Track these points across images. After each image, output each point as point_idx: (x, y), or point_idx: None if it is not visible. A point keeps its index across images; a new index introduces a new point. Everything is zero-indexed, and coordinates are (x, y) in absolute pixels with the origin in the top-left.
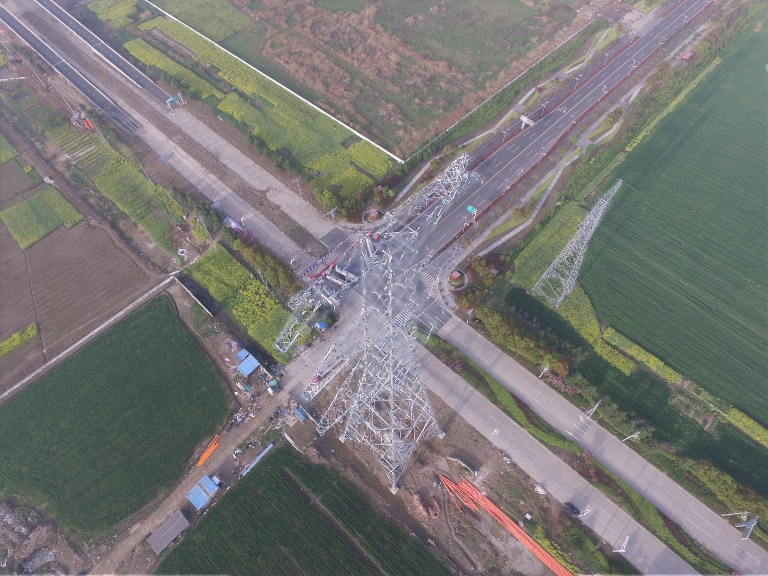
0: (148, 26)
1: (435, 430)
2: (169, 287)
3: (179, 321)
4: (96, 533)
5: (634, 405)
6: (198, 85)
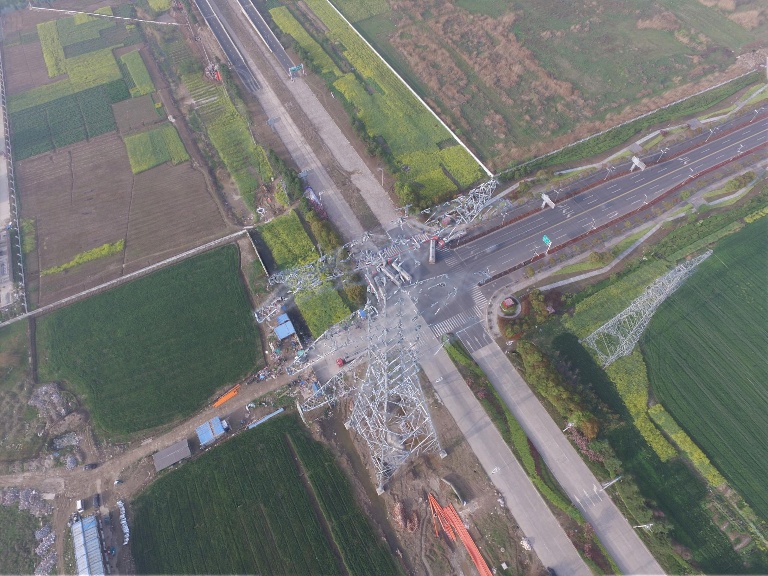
0: None
1: (436, 447)
2: (240, 239)
3: (239, 272)
4: (116, 434)
5: (659, 494)
6: (322, 60)
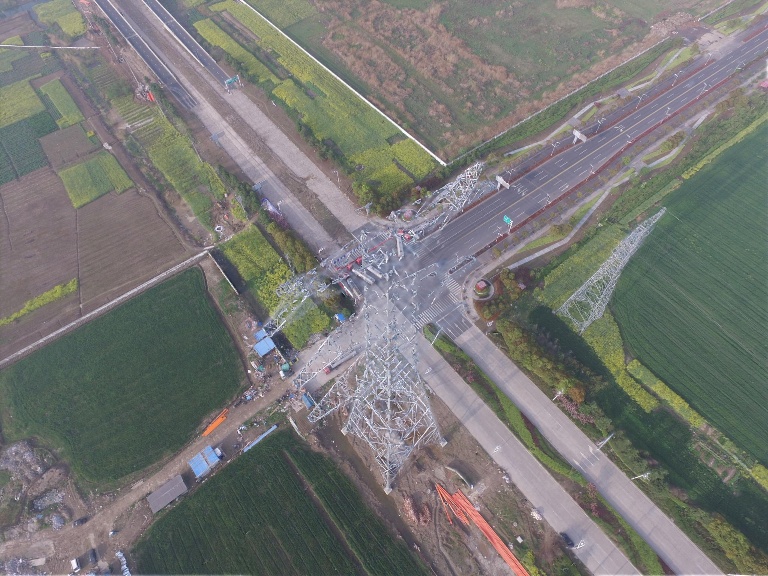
0: (219, 8)
1: (436, 437)
2: (202, 261)
3: (206, 294)
4: (102, 483)
5: (650, 444)
6: (257, 69)
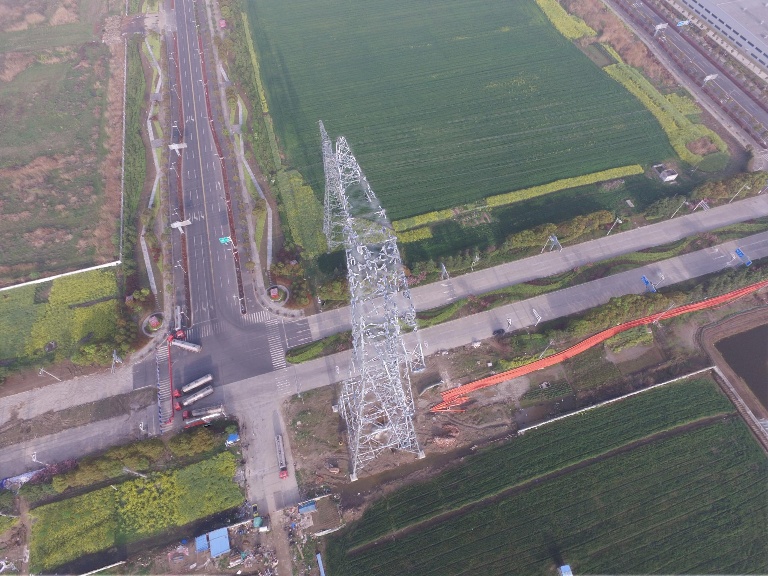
0: None
1: None
2: None
3: None
4: None
5: (453, 248)
6: None
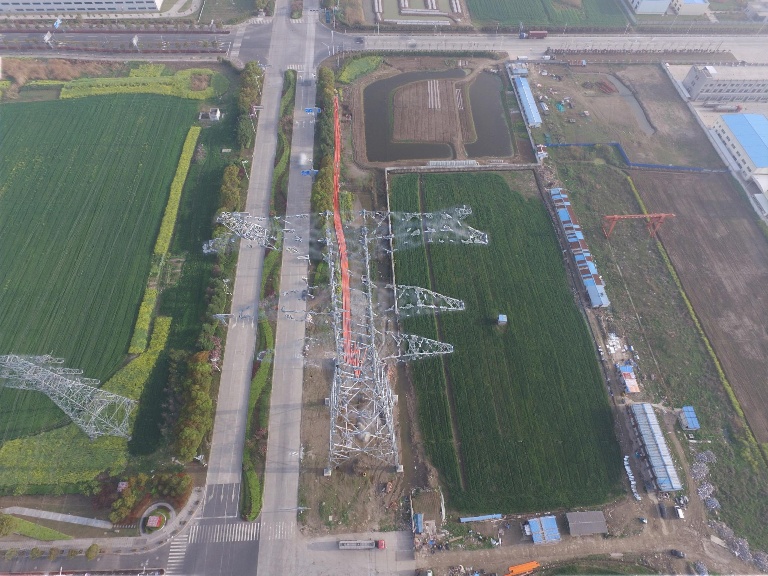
0: None
1: None
2: None
3: None
4: None
5: (196, 302)
6: None
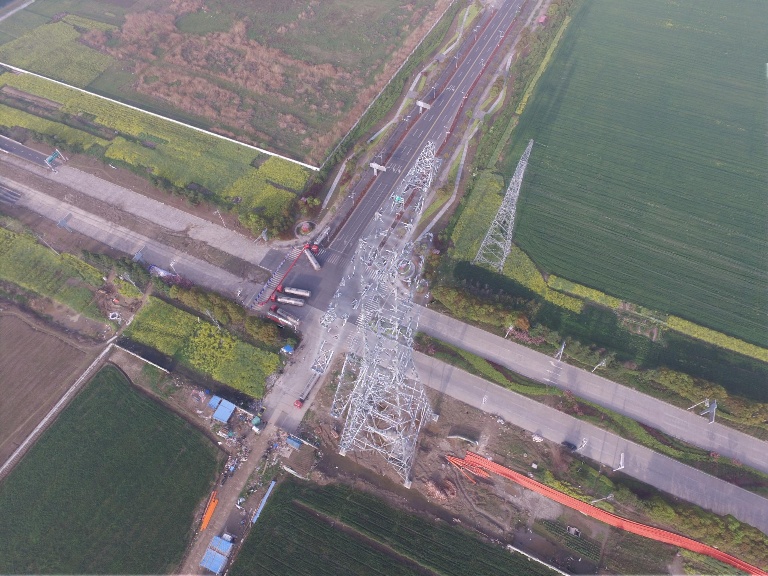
0: None
1: (430, 415)
2: (110, 356)
3: (133, 388)
4: None
5: (592, 338)
6: (75, 137)
